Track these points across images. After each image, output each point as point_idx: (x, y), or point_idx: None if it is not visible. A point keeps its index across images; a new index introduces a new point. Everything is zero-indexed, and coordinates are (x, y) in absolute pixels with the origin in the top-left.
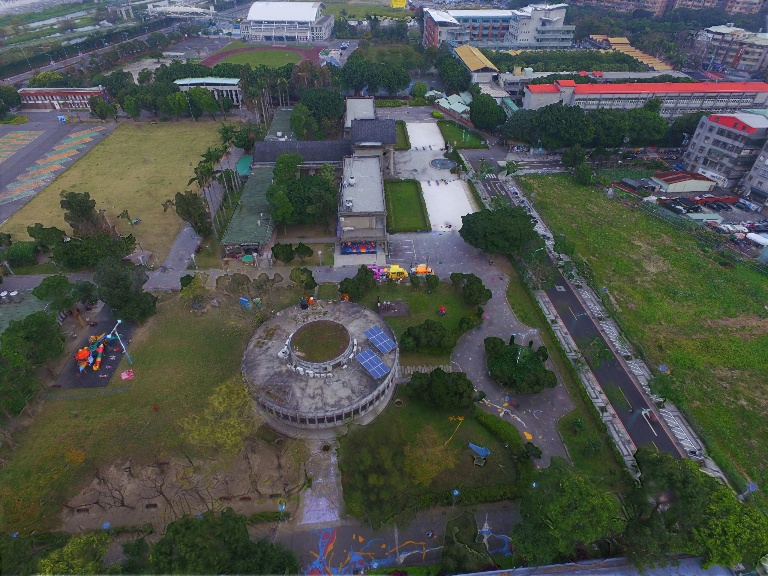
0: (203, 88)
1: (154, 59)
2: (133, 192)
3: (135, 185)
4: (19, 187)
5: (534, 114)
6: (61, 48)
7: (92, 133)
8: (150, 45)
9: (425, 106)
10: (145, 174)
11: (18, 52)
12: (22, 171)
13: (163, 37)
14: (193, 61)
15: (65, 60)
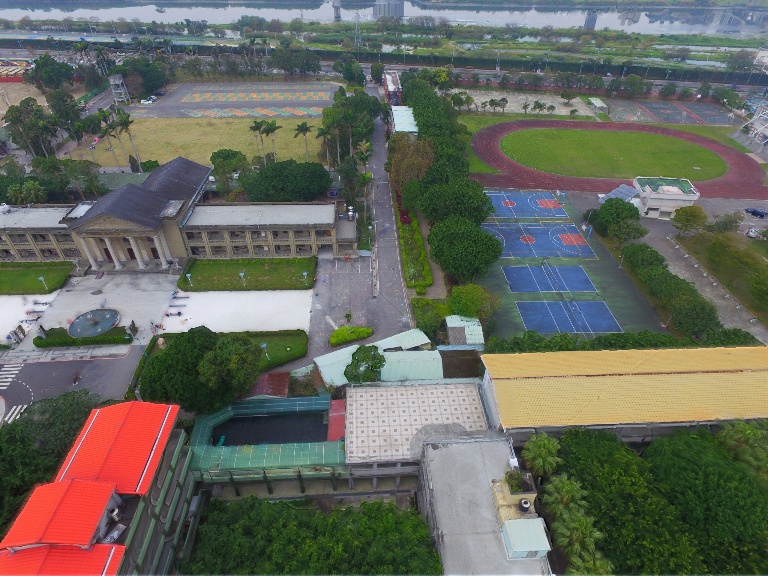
0: (331, 111)
1: (581, 100)
2: (169, 142)
3: (183, 140)
4: (210, 111)
5: (32, 426)
6: (540, 61)
7: (317, 112)
8: (610, 87)
9: (414, 322)
10: (204, 141)
11: (553, 58)
12: (240, 107)
13: (636, 84)
14: (589, 117)
15: (535, 73)
